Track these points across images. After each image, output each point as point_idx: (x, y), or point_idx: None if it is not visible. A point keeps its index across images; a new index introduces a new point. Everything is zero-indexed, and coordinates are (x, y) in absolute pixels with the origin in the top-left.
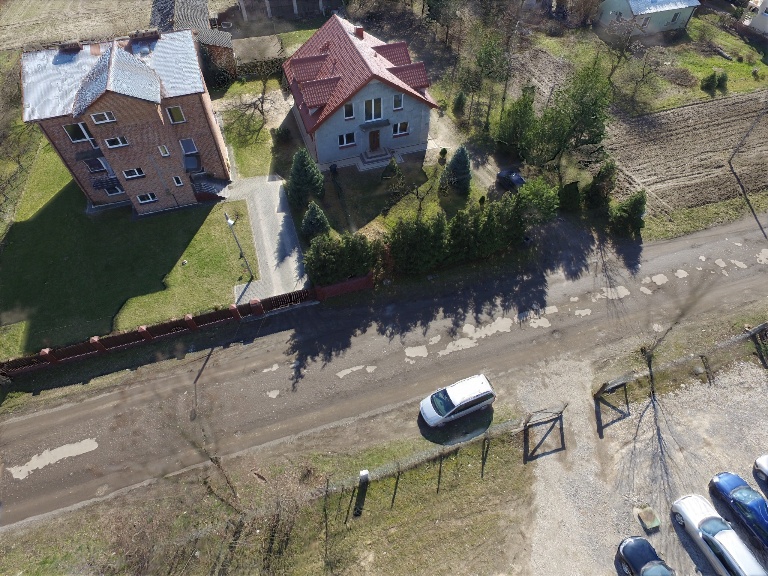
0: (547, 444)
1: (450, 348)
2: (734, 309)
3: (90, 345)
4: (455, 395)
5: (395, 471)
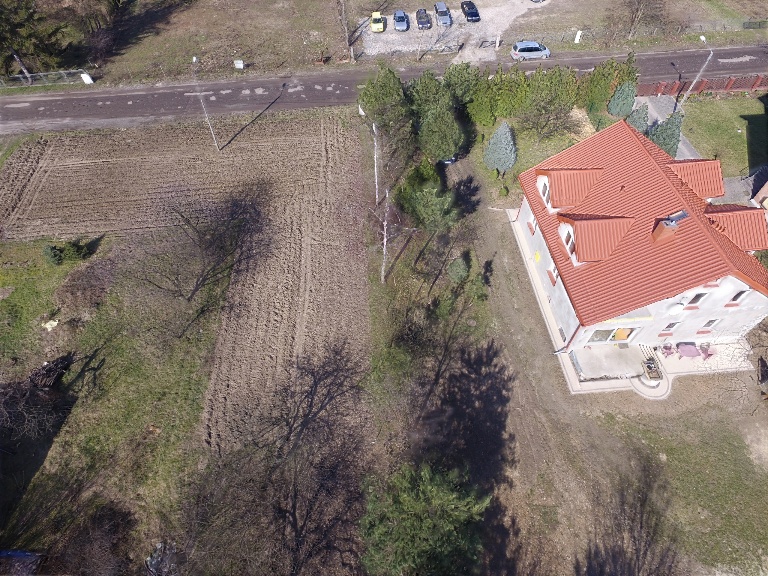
0: (490, 43)
1: (529, 72)
2: (350, 71)
3: (762, 79)
4: (535, 43)
5: (563, 42)
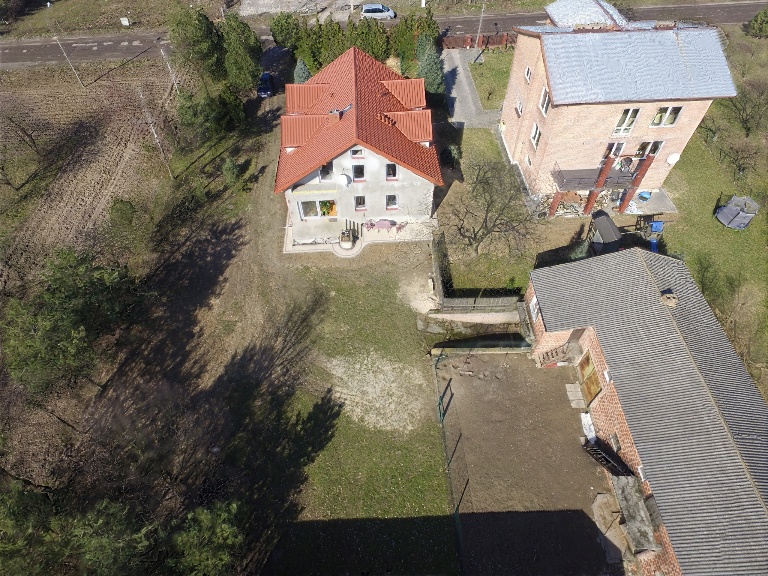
0: (349, 7)
1: None
2: None
3: None
4: (379, 5)
5: (411, 6)
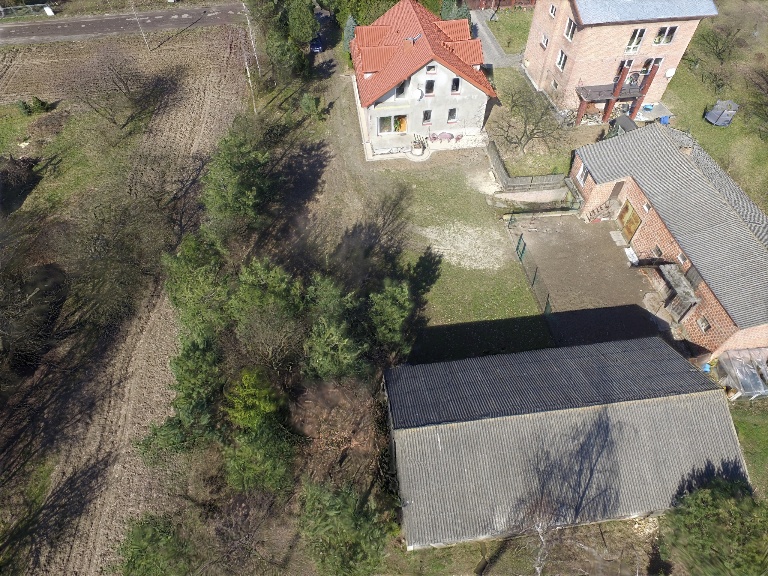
0: None
1: None
2: None
3: None
4: None
5: None
